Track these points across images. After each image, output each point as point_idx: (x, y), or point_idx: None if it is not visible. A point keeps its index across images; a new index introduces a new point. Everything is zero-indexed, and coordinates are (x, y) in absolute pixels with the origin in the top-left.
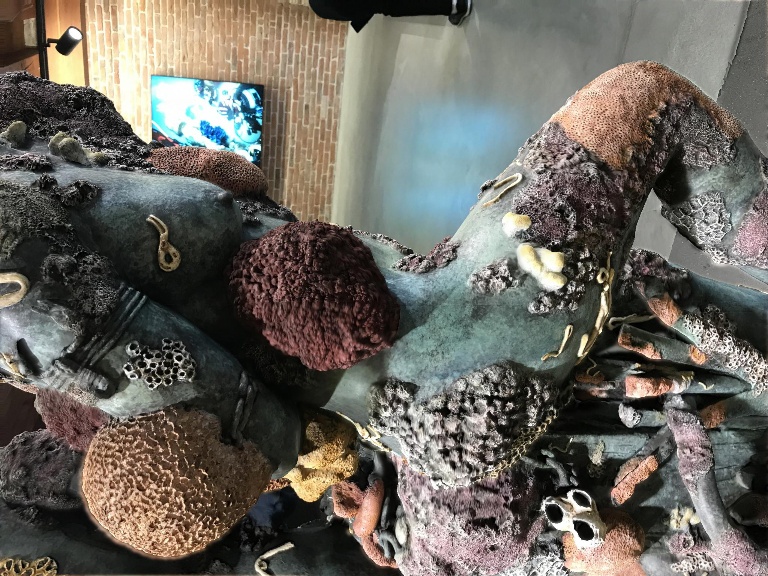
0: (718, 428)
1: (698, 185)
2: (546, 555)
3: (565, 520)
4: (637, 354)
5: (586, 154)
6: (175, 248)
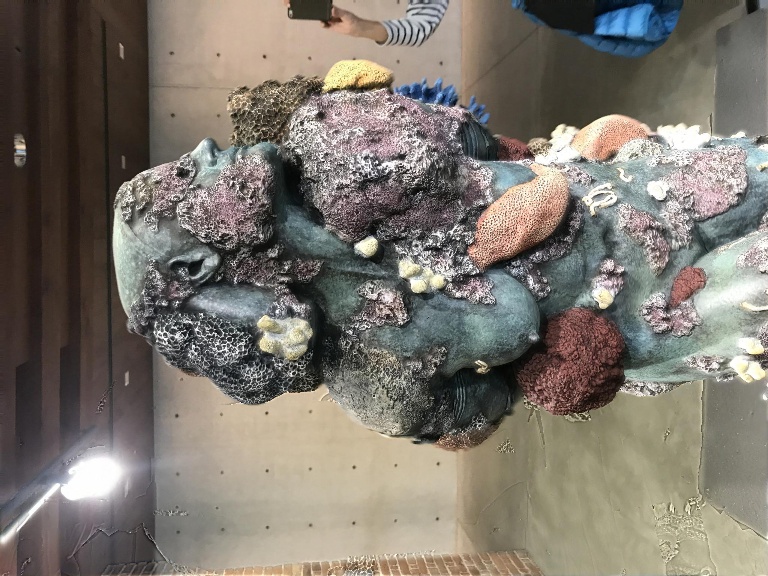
0: None
1: None
2: None
3: None
4: None
5: None
6: (489, 368)
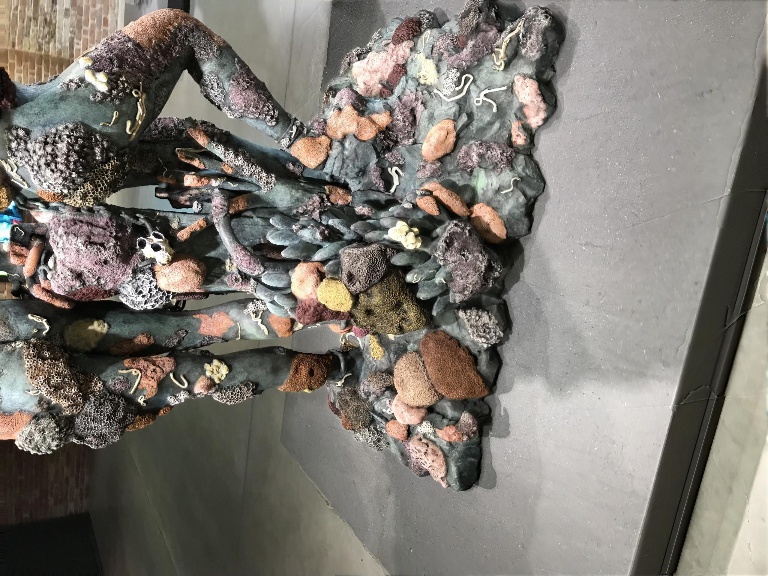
0: (252, 217)
1: (204, 69)
2: (143, 274)
3: (148, 246)
4: (193, 167)
5: (128, 38)
6: None
